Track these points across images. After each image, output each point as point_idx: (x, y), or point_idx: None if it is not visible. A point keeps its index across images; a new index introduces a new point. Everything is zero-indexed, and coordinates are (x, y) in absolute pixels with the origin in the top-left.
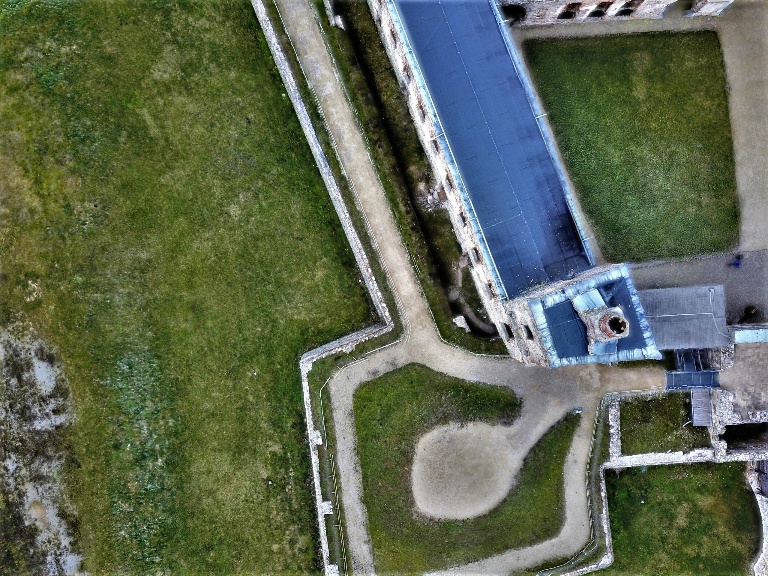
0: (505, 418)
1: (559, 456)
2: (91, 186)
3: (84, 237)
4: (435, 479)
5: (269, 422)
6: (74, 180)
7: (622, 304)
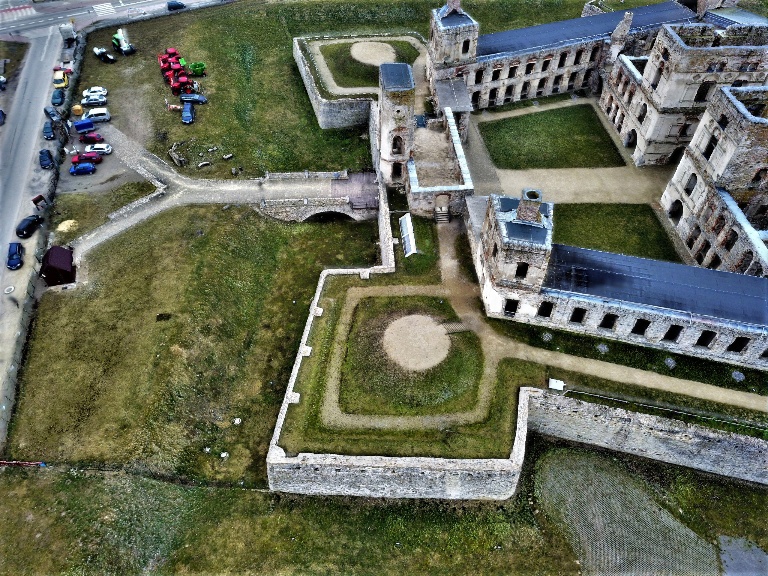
0: None
1: None
2: (483, 5)
3: (462, 1)
4: (369, 46)
5: None
6: (484, 1)
7: None
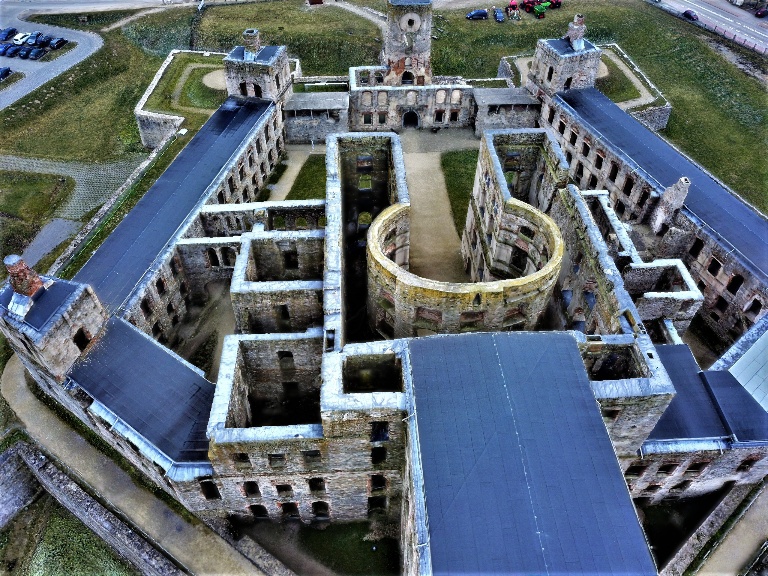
0: None
1: None
2: None
3: None
4: None
5: (672, 109)
6: None
7: (562, 47)
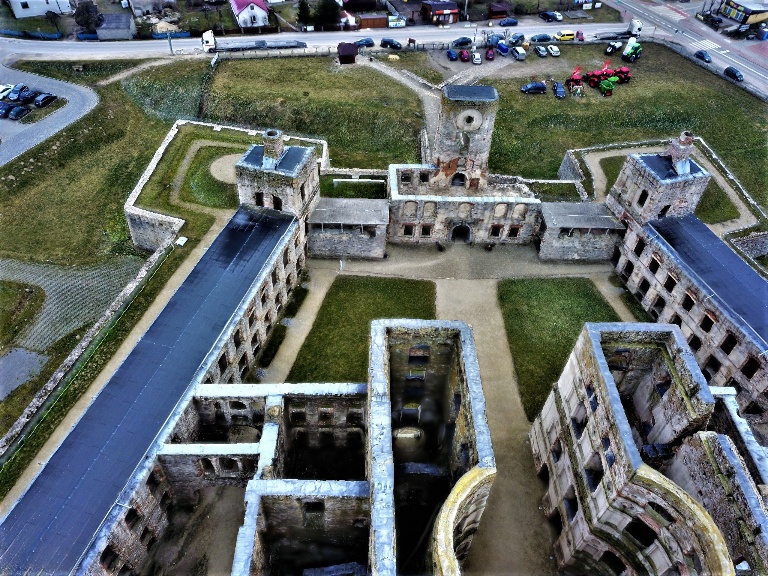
0: None
1: (612, 183)
2: None
3: None
4: None
5: None
6: None
7: (662, 169)
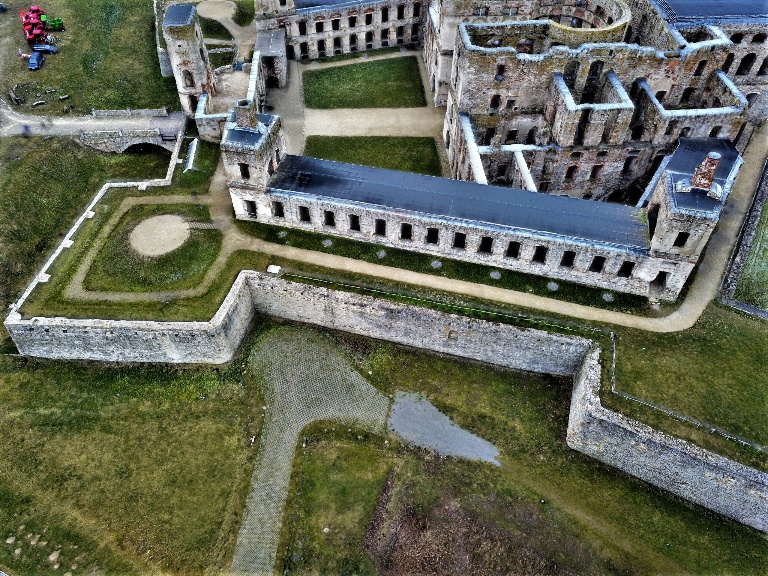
0: (235, 19)
1: None
2: None
3: None
4: None
5: None
6: None
7: None
